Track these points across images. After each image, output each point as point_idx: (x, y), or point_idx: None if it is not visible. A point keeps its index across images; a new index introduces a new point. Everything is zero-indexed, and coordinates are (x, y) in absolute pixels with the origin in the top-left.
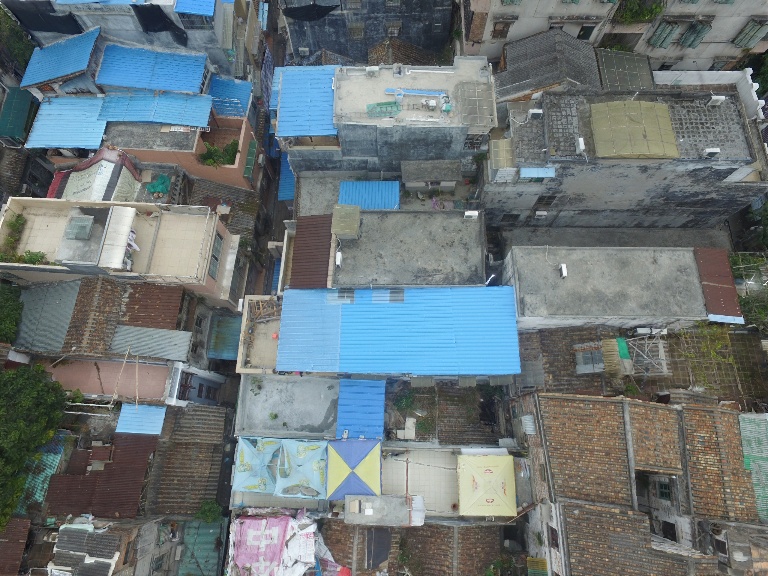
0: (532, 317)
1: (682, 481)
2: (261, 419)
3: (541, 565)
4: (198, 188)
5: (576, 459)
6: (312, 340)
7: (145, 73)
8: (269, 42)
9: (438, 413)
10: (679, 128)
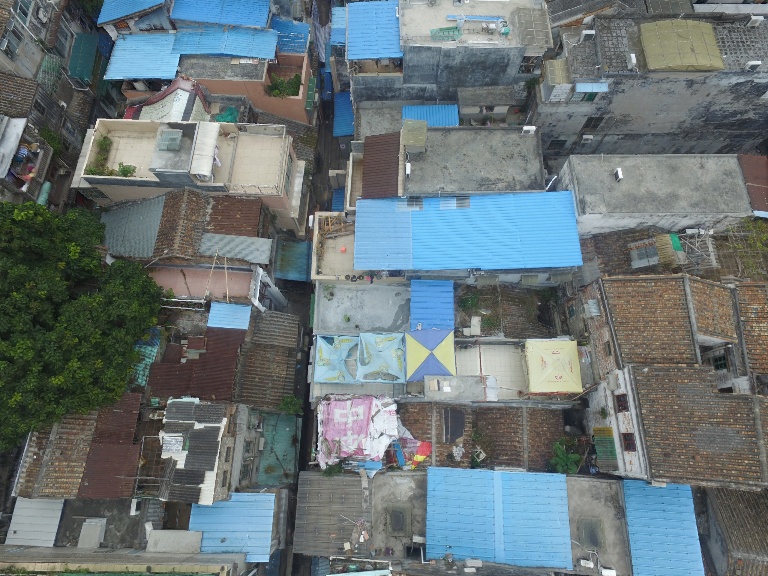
0: (592, 215)
1: (737, 349)
2: (334, 323)
3: (607, 433)
4: (262, 121)
5: (641, 330)
6: (386, 243)
7: (215, 9)
8: None
9: (502, 311)
10: (722, 46)
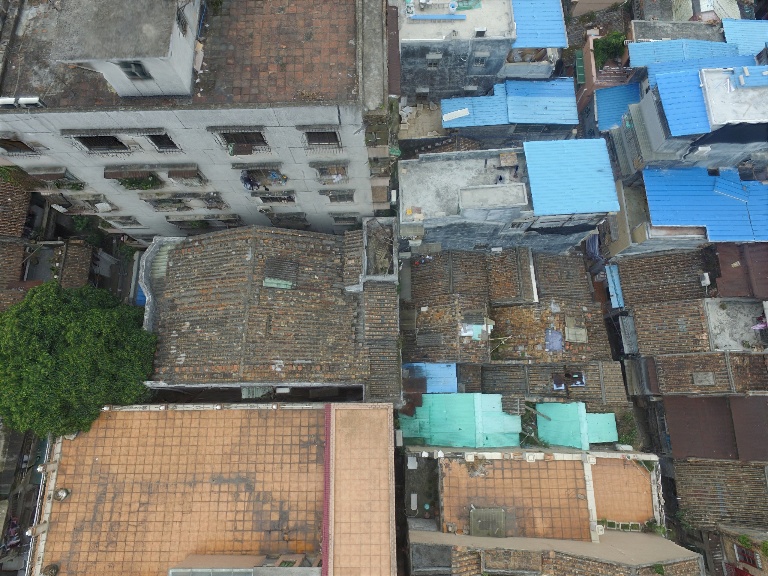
0: None
1: None
2: None
3: None
4: None
5: None
6: None
7: None
8: None
9: None
10: None
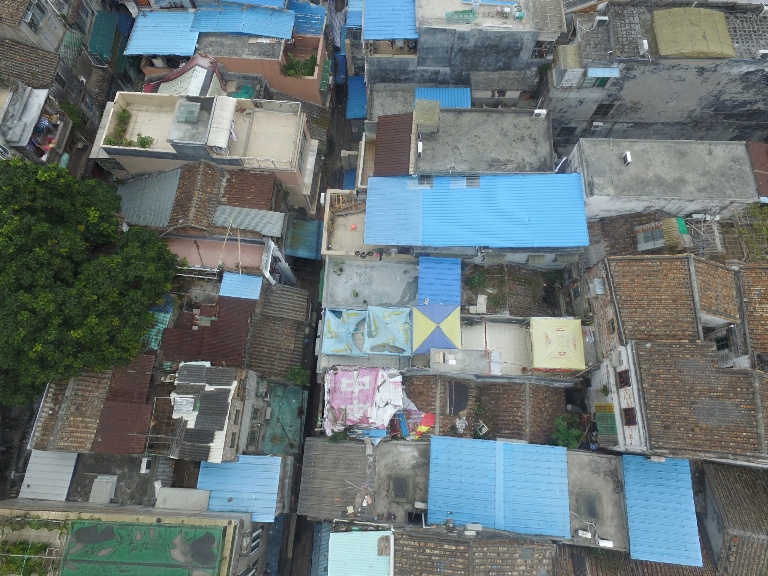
0: (599, 197)
1: (740, 329)
2: (343, 298)
3: (608, 409)
4: None
5: (645, 307)
6: (396, 219)
7: None
8: None
9: (508, 290)
10: (734, 35)
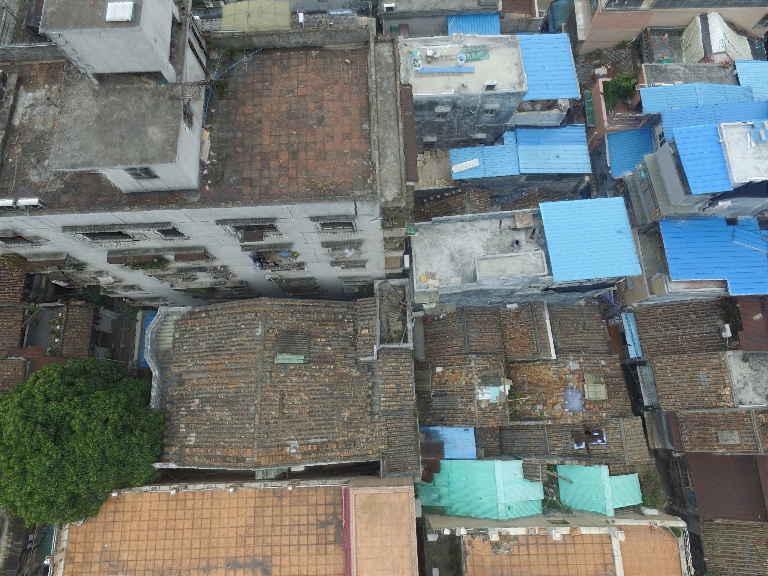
0: None
1: None
2: None
3: None
4: None
5: None
6: None
7: (725, 121)
8: (616, 350)
9: None
10: None
